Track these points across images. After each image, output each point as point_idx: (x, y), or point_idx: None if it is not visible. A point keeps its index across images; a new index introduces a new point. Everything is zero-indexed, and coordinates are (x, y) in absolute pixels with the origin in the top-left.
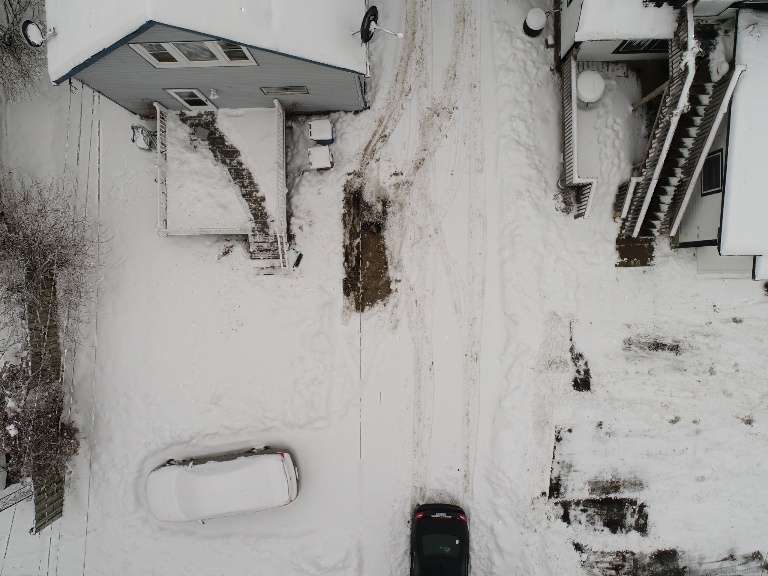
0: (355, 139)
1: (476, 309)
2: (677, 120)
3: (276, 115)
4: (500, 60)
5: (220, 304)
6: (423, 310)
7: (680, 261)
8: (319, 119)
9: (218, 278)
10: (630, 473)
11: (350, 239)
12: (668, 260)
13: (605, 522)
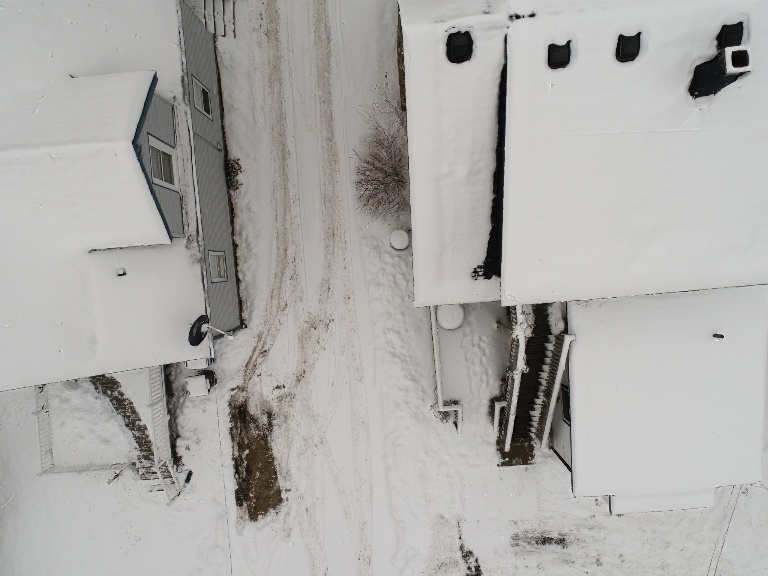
0: (235, 357)
1: (366, 514)
2: (519, 376)
3: None
4: (370, 274)
5: (117, 521)
6: (314, 518)
7: (559, 460)
8: None
9: (113, 496)
10: None
11: (239, 451)
12: (547, 461)
13: None
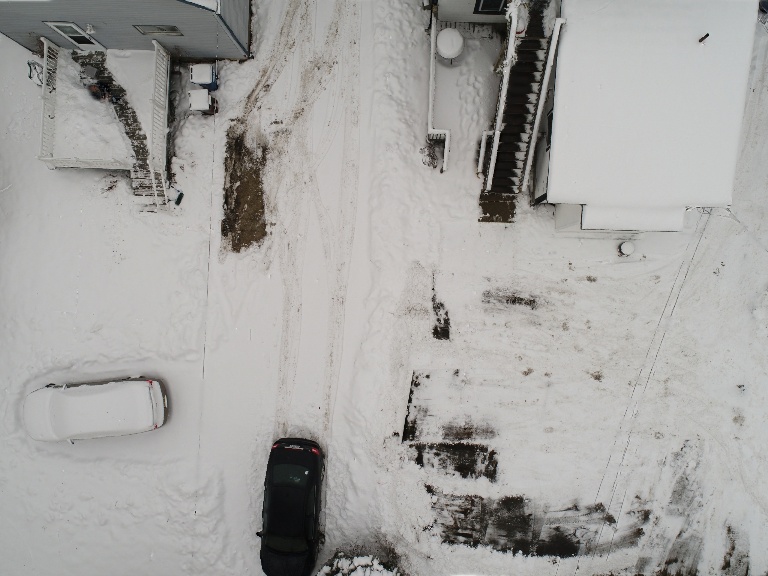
0: (239, 87)
1: (345, 255)
2: (508, 71)
3: (155, 55)
4: (378, 18)
5: (105, 237)
6: (294, 253)
7: (539, 219)
8: (200, 64)
9: (104, 212)
10: (483, 421)
11: (231, 182)
12: (526, 217)
13: (456, 466)
